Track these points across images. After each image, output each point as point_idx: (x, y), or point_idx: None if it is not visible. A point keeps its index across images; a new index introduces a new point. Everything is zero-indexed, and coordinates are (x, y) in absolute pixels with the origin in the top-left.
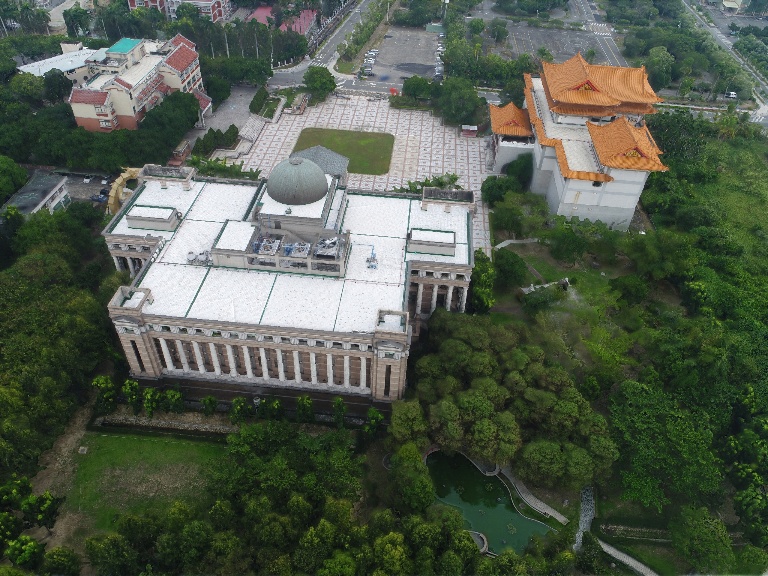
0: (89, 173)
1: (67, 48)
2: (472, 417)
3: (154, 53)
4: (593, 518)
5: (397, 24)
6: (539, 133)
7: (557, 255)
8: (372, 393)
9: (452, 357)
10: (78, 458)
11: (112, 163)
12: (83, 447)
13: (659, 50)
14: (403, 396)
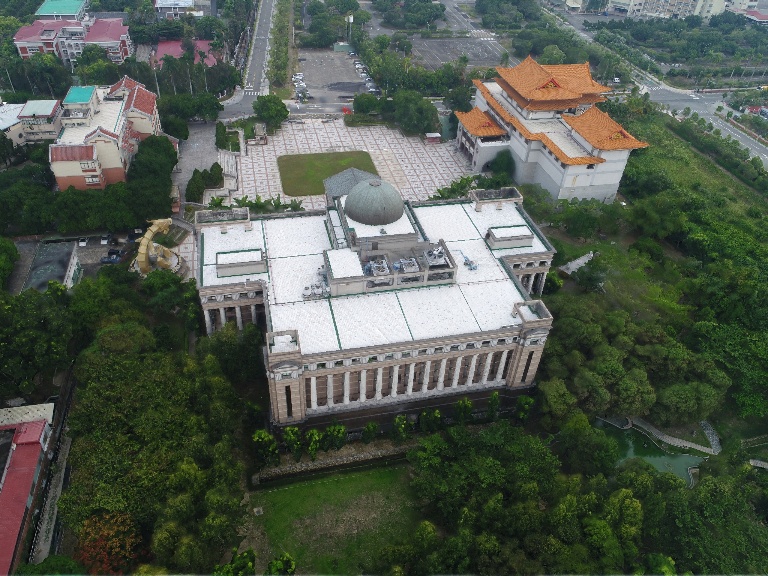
0: (87, 235)
1: None
2: (614, 379)
3: (108, 99)
4: (719, 440)
5: (304, 47)
6: (521, 130)
7: (575, 233)
8: (508, 383)
9: (571, 333)
10: (259, 520)
11: (119, 220)
12: (257, 508)
13: (552, 48)
14: (534, 379)
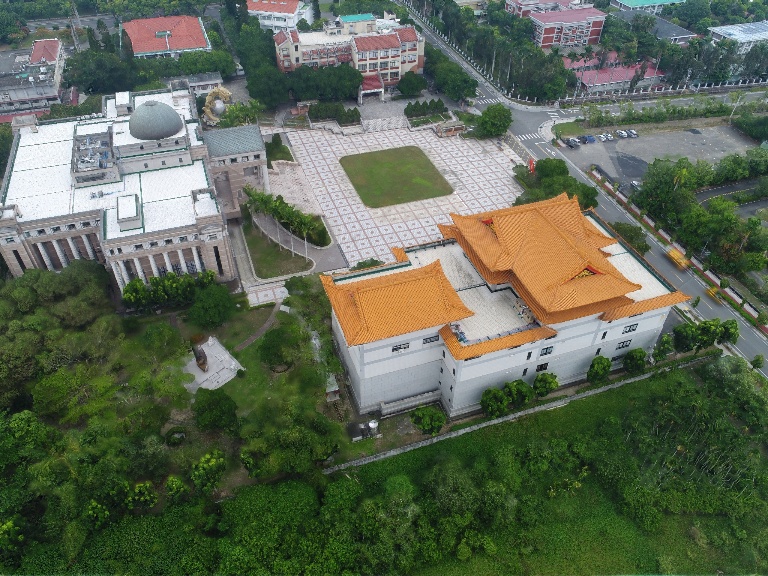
0: None
1: (386, 16)
2: None
3: None
4: None
5: (738, 126)
6: None
7: None
8: None
9: None
10: None
11: None
12: None
13: None
14: None
